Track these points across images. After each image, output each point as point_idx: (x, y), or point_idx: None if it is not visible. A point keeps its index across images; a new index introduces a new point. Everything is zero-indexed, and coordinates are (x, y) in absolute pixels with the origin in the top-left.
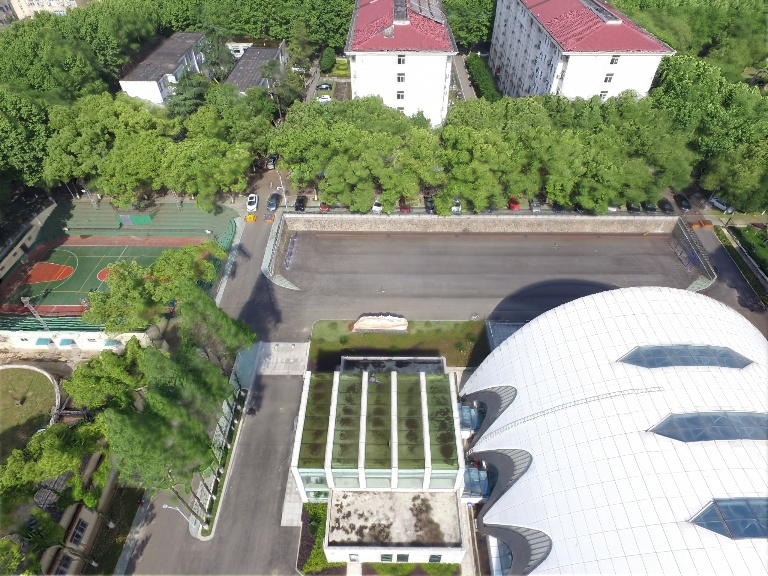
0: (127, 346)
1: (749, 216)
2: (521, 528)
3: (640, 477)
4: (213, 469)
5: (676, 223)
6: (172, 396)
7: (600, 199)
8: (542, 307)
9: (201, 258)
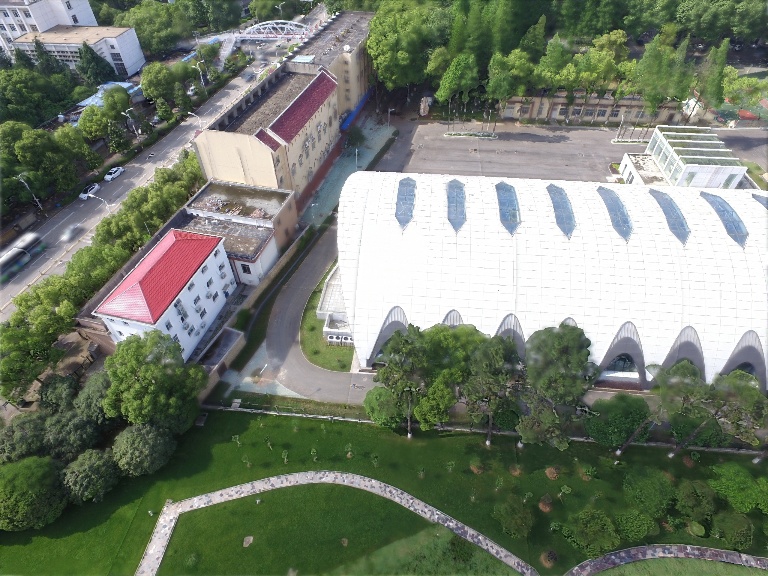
0: None
1: None
2: None
3: None
4: (642, 131)
5: None
6: (671, 66)
7: None
8: None
9: (760, 89)
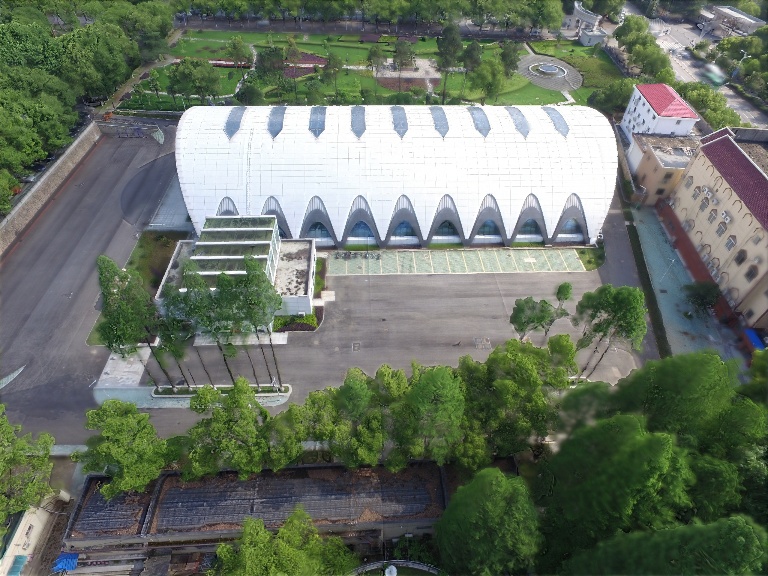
0: (80, 455)
1: (112, 99)
2: (306, 213)
3: (295, 149)
4: None
5: (97, 126)
6: None
7: (59, 135)
8: (144, 202)
9: None
